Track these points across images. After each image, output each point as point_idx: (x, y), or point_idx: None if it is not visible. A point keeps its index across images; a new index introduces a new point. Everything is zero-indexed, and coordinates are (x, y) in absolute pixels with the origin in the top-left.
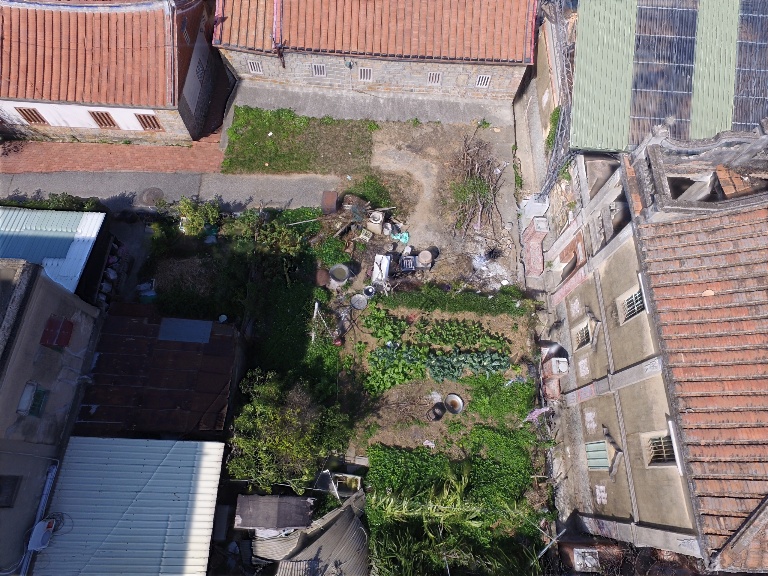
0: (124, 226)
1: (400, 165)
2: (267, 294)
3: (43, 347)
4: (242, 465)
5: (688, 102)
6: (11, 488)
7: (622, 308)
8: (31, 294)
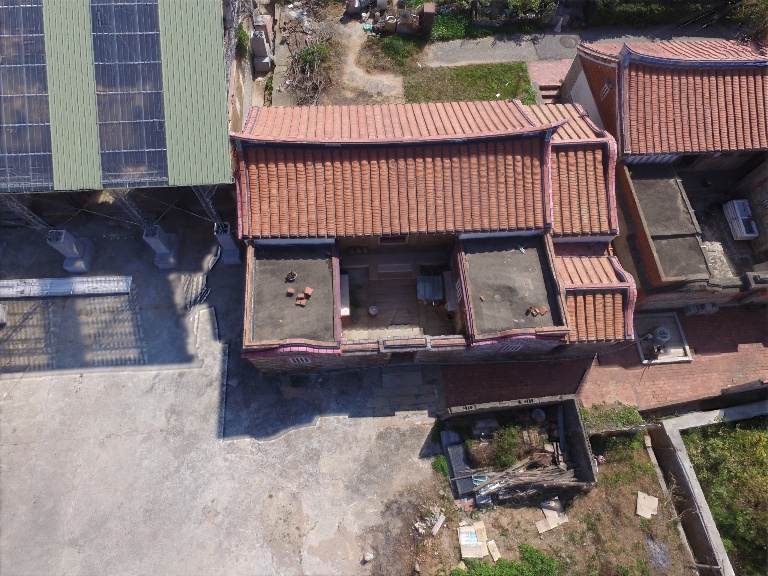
0: None
1: (377, 79)
2: None
3: None
4: None
5: None
6: None
7: None
8: None
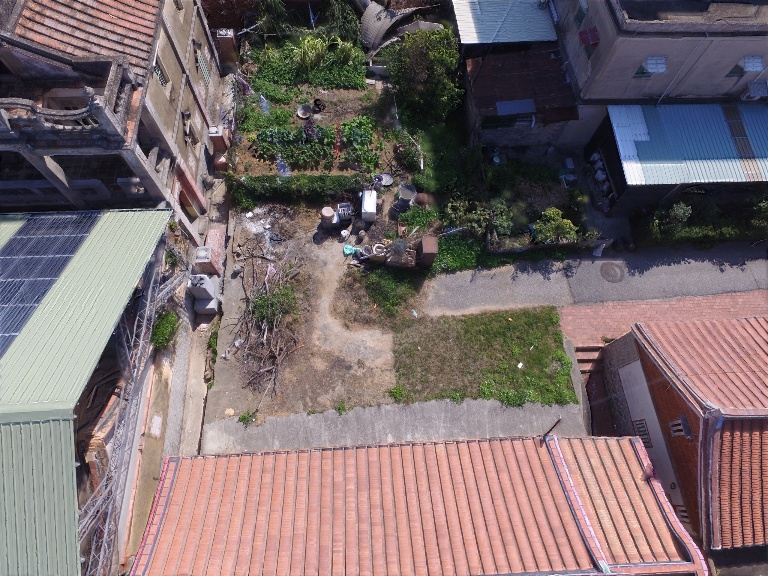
0: None
1: (358, 338)
2: None
3: None
4: None
5: (3, 251)
6: None
7: (166, 91)
8: None
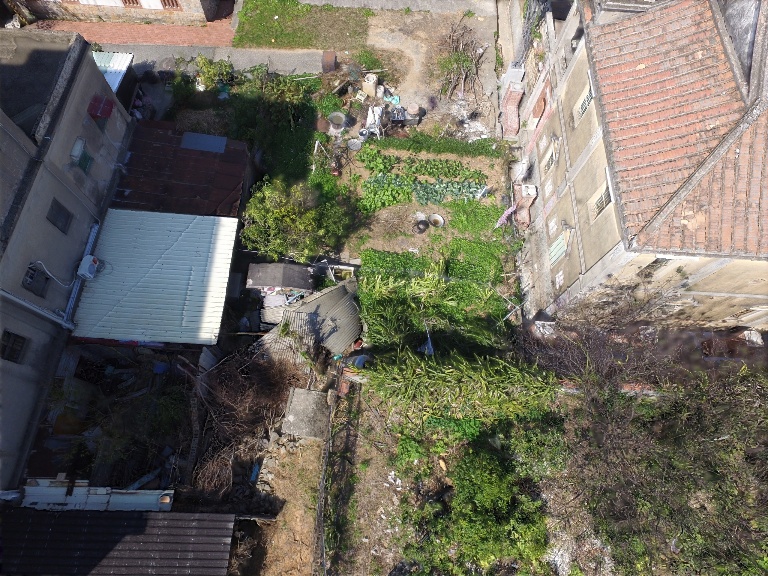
0: (146, 86)
1: (393, 44)
2: (273, 136)
3: (89, 116)
4: (253, 231)
5: None
6: (65, 220)
7: (577, 114)
8: (82, 60)
